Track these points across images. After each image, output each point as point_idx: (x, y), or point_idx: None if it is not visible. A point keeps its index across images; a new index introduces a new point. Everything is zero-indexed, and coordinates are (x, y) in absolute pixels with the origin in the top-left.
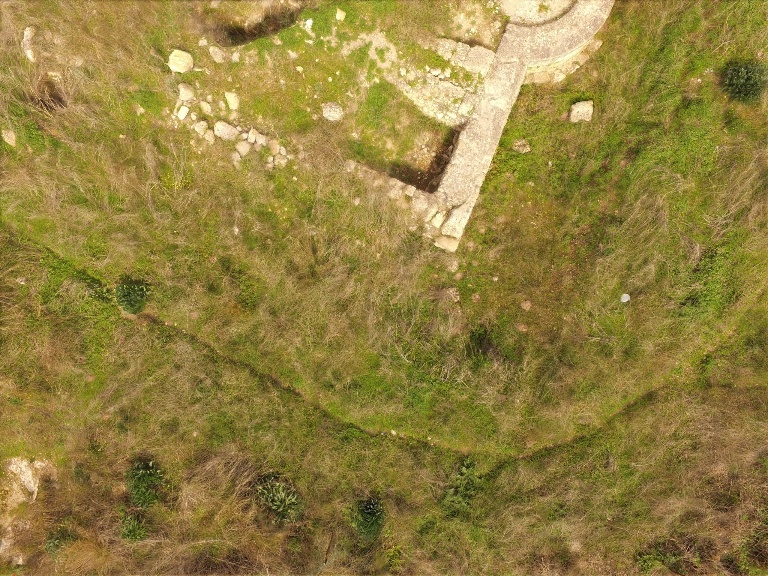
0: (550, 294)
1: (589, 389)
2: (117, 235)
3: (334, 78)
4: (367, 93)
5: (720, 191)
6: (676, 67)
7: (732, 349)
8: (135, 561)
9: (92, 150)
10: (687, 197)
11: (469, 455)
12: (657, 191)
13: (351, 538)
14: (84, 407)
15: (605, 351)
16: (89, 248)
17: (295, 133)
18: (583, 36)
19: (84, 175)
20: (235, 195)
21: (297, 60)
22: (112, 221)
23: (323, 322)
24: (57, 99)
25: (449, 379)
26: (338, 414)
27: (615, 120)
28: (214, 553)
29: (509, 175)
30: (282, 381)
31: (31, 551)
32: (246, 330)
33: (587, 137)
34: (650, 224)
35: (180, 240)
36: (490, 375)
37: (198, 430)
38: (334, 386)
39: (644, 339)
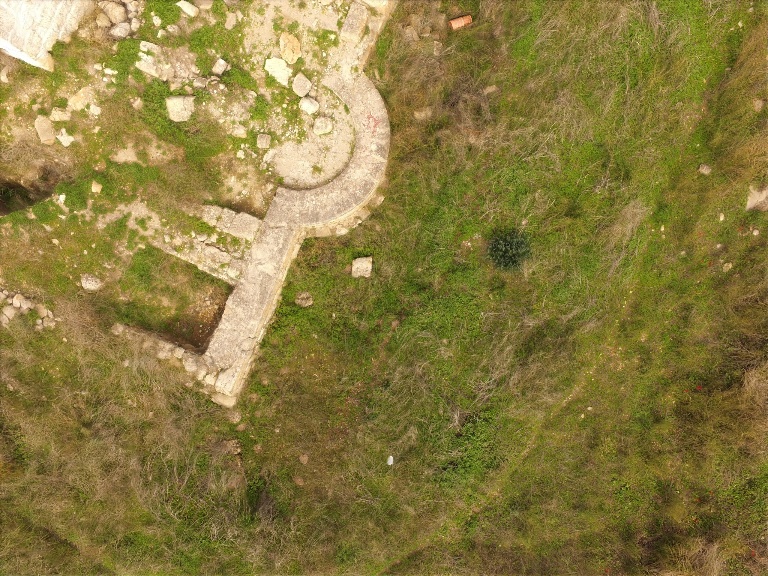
0: (324, 451)
1: (353, 550)
2: None
3: (89, 251)
4: (132, 259)
5: (479, 361)
6: (448, 230)
7: (496, 511)
8: None
9: None
10: (452, 362)
11: None
12: (423, 356)
13: None
14: None
15: (371, 512)
16: None
17: (60, 298)
18: (352, 200)
19: None
20: None
21: (51, 233)
22: None
23: (89, 484)
24: None
25: (218, 538)
26: (112, 569)
27: (389, 280)
28: None
29: (291, 328)
30: (59, 534)
31: None
32: (12, 492)
33: (367, 292)
34: (404, 397)
35: None
36: (257, 535)
37: None
38: (107, 542)
39: (404, 504)
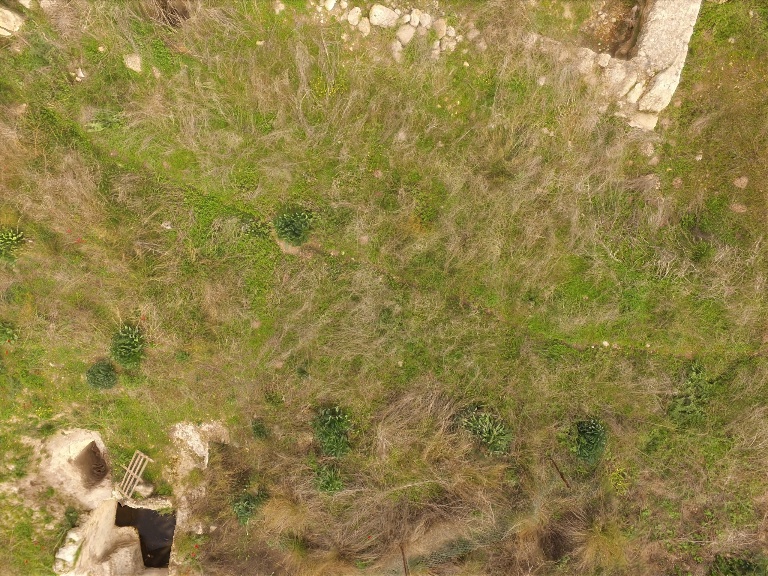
0: None
1: None
2: (269, 158)
3: None
4: None
5: None
6: None
7: None
8: (335, 514)
9: (229, 62)
10: None
11: (696, 359)
12: None
13: (571, 465)
14: (253, 357)
15: None
16: (236, 179)
17: (465, 7)
18: None
19: (222, 94)
20: (407, 88)
21: None
22: (259, 144)
23: (520, 225)
24: (180, 9)
25: (668, 275)
26: (541, 330)
27: None
28: (416, 498)
29: (705, 33)
30: (471, 302)
31: (210, 519)
32: (433, 245)
33: None
34: None
35: (343, 153)
36: (717, 264)
37: (384, 367)
38: (534, 299)
39: None
